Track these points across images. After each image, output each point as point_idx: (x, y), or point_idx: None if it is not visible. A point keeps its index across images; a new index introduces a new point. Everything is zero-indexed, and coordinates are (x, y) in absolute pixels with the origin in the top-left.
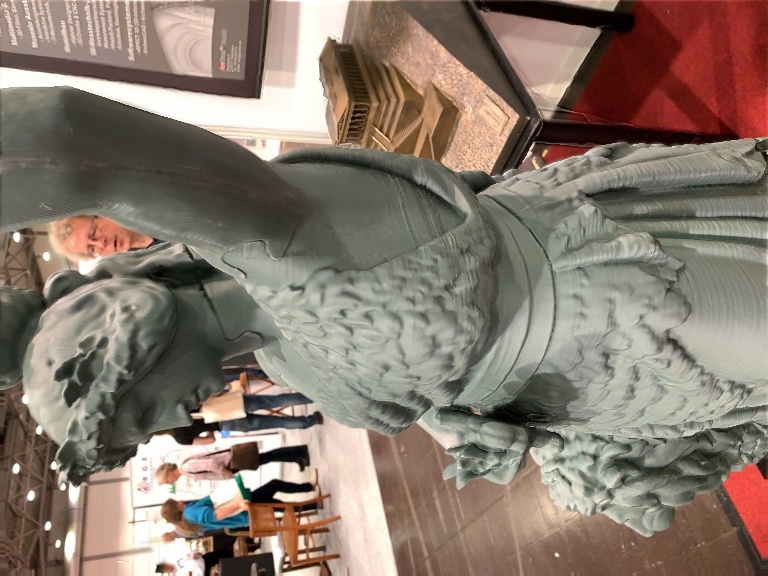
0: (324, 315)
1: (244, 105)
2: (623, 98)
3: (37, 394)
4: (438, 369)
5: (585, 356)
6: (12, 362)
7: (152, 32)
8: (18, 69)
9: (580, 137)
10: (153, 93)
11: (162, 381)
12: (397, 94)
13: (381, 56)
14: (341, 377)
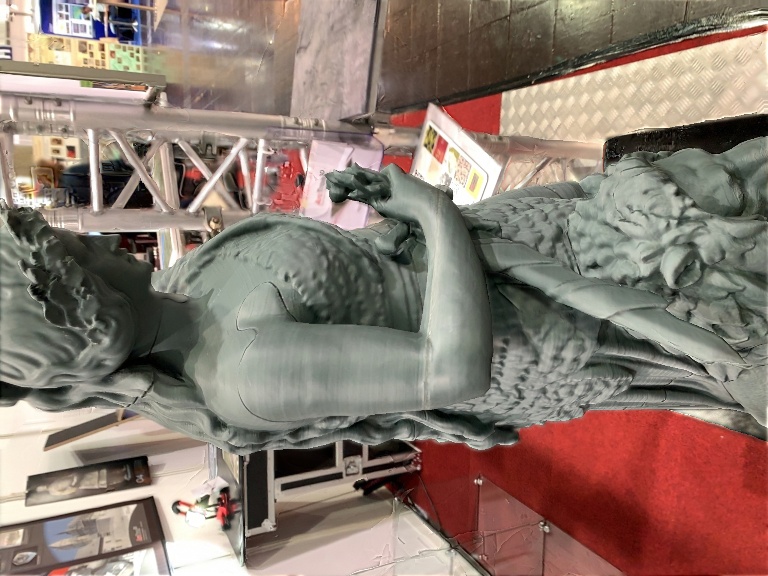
0: None
1: None
2: None
3: None
4: None
5: None
6: None
7: None
8: None
9: None
10: None
11: None
12: None
13: None
14: None
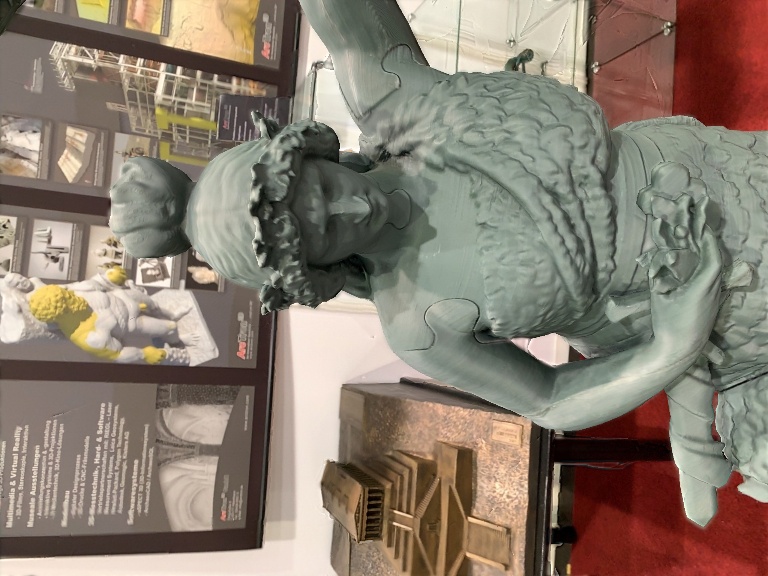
0: (471, 92)
1: (244, 563)
2: (613, 471)
3: (222, 161)
4: (583, 121)
5: (701, 169)
6: (181, 190)
7: (156, 487)
8: (2, 559)
9: (595, 453)
10: (144, 569)
11: (338, 167)
12: (408, 466)
13: (382, 450)
14: (502, 153)
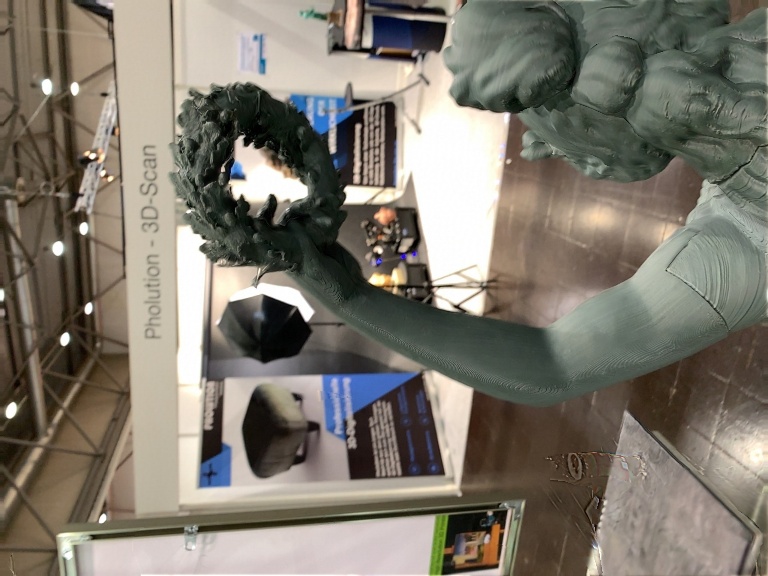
0: None
1: None
2: None
3: None
4: None
5: None
6: None
7: None
8: None
9: None
10: None
11: None
12: None
13: None
14: None
